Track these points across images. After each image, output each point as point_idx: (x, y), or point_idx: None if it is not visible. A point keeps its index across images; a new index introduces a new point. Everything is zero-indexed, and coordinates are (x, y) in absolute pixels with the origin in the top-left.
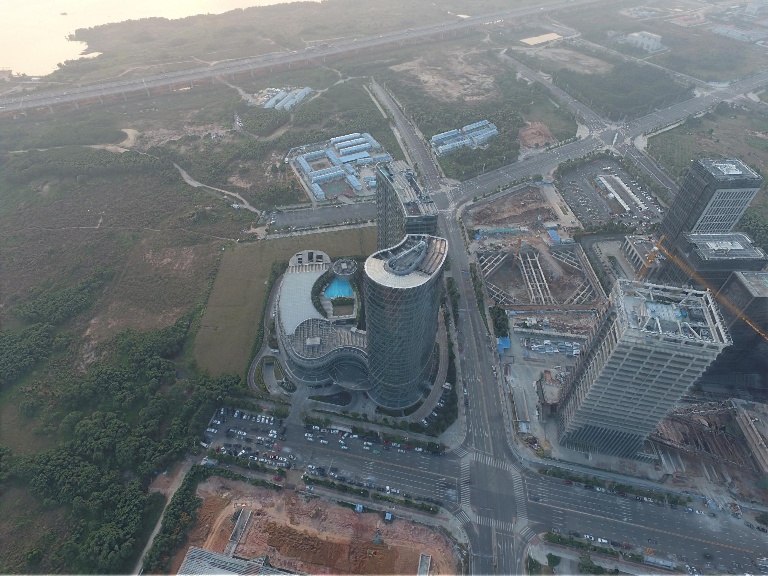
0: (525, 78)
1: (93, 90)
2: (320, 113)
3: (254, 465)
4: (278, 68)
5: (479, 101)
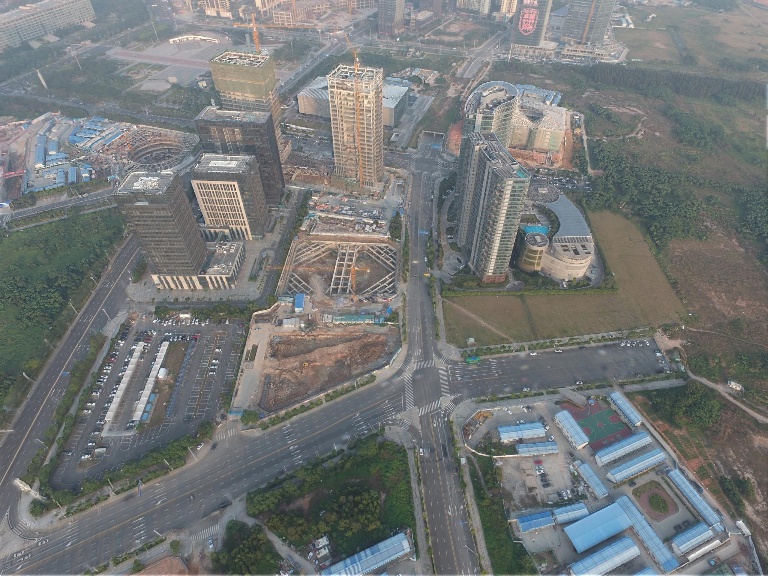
0: None
1: None
2: None
3: None
4: None
5: None
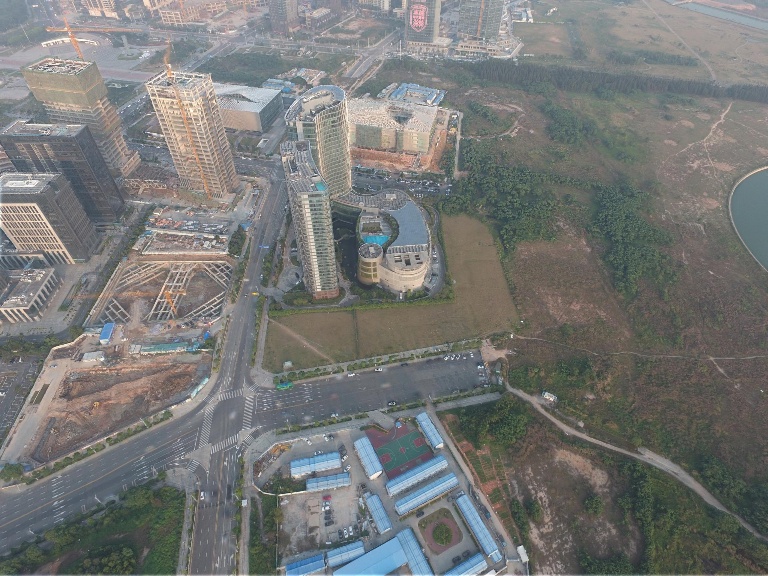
0: None
1: None
2: None
3: None
4: None
5: None
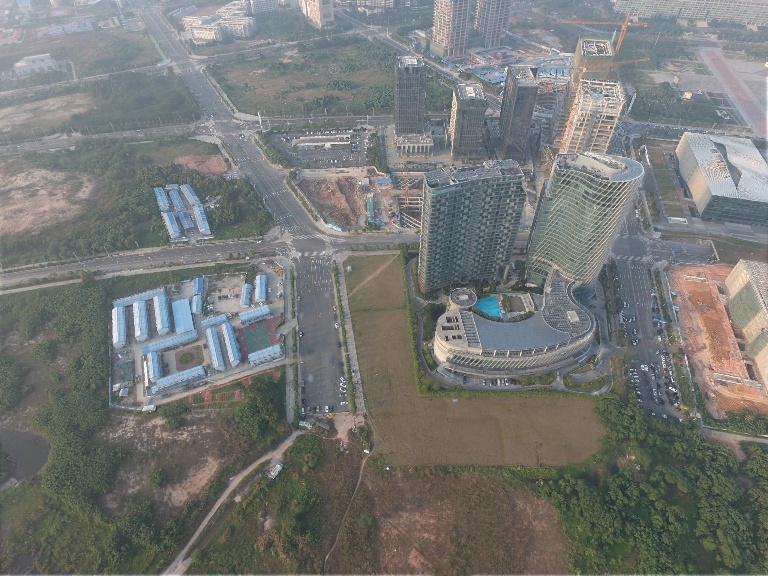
0: (52, 150)
1: None
2: None
3: None
4: None
5: (96, 188)
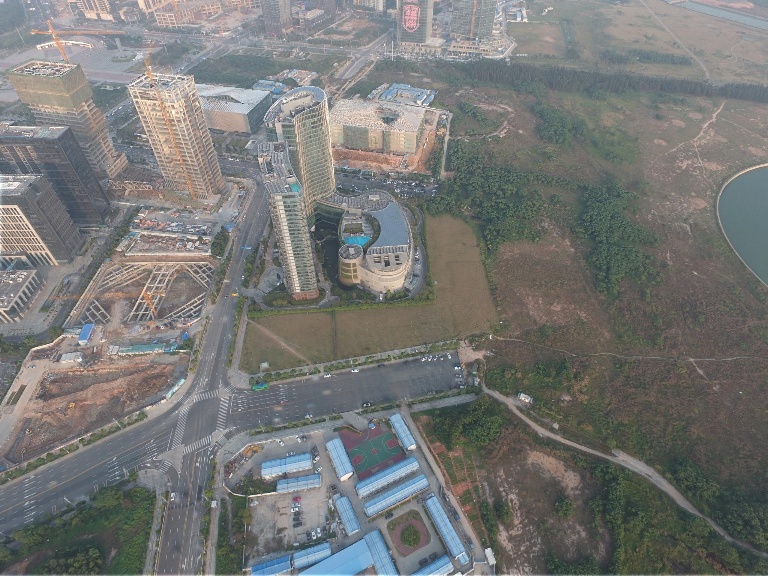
0: None
1: None
2: None
3: None
4: None
5: None
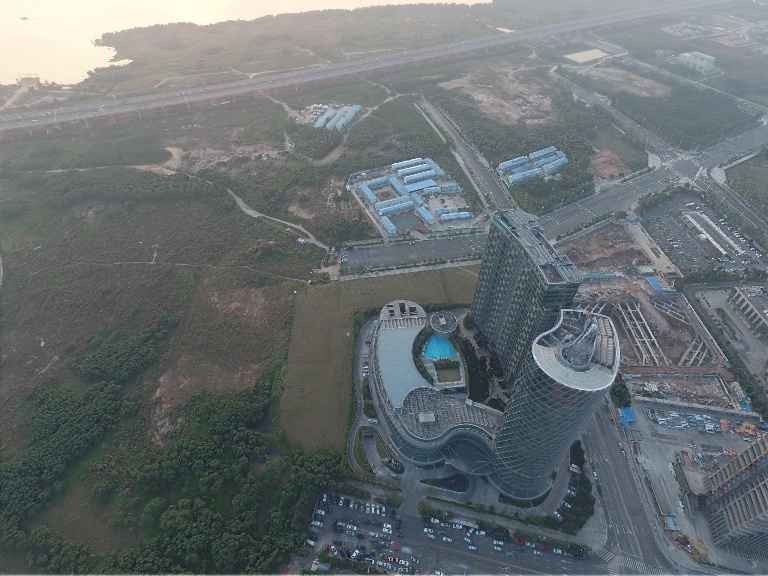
0: (582, 99)
1: (131, 103)
2: (375, 134)
3: (375, 572)
4: (322, 82)
5: (540, 125)
